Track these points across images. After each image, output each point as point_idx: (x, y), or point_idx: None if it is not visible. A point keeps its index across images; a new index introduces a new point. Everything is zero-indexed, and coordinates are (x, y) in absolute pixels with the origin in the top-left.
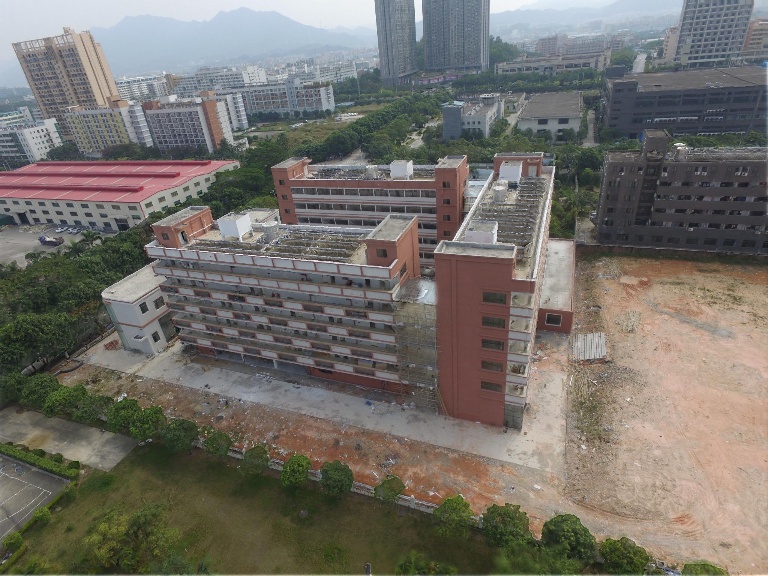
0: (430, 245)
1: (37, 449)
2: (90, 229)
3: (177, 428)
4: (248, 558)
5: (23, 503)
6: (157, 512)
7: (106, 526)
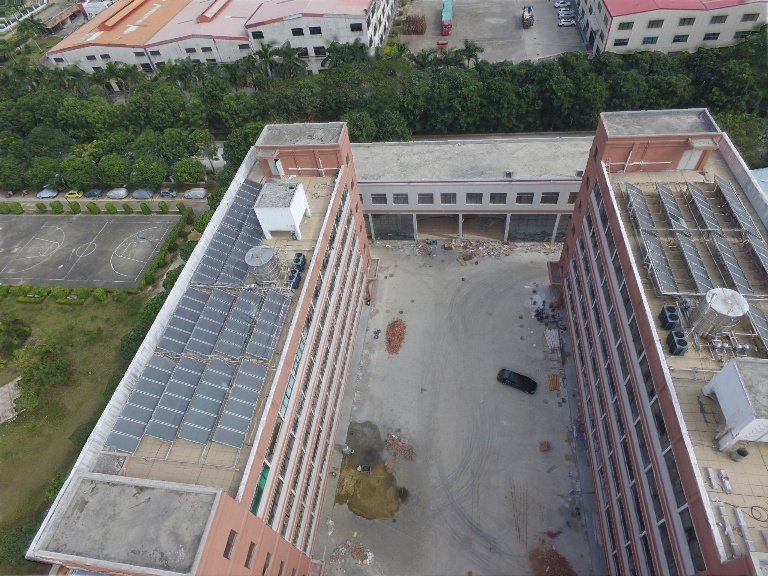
0: (628, 570)
1: (186, 240)
2: (575, 20)
3: (128, 340)
4: (18, 477)
5: (127, 272)
6: (44, 380)
7: (21, 353)
